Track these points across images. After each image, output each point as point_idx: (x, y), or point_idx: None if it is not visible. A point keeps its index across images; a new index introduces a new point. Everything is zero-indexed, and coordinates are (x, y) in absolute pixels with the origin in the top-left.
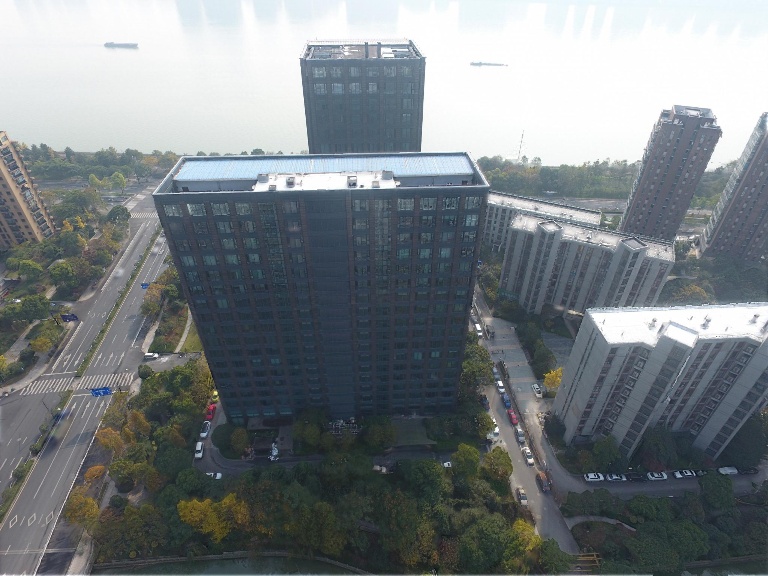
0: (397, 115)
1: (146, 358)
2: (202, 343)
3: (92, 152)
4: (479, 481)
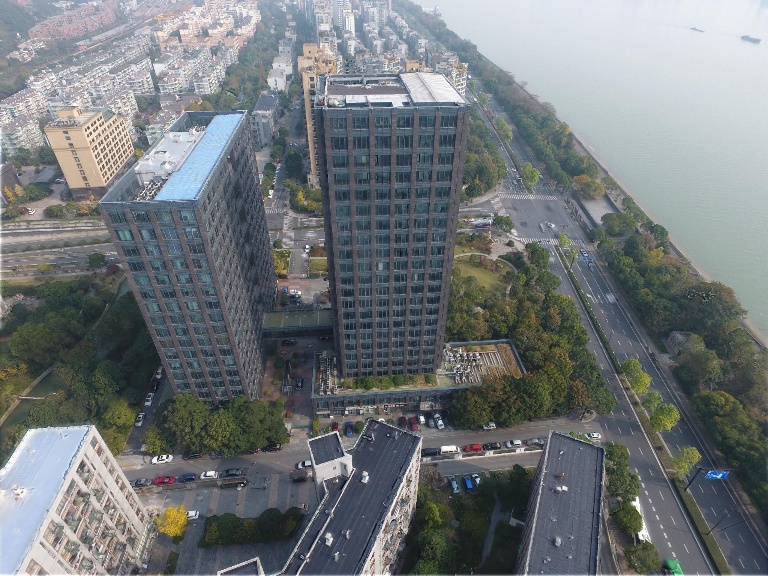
0: None
1: None
2: None
3: (594, 156)
4: (97, 425)
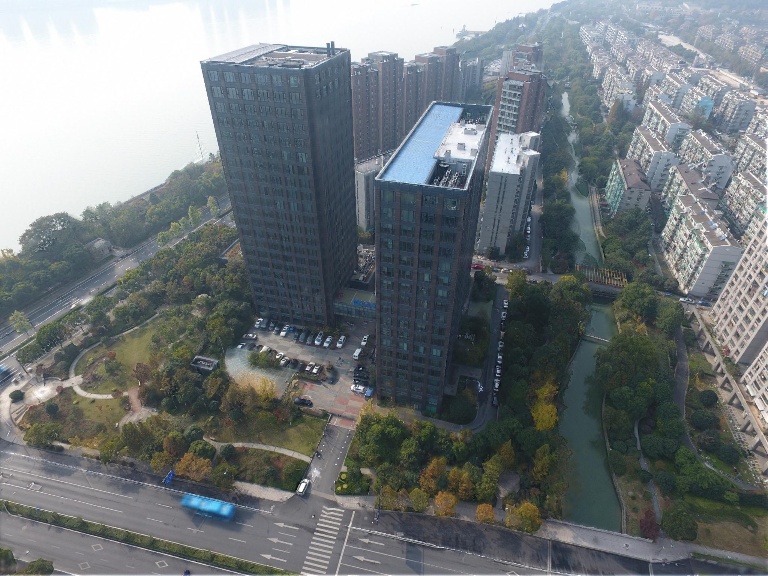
0: (346, 103)
1: (304, 493)
2: (449, 333)
3: None
4: None
